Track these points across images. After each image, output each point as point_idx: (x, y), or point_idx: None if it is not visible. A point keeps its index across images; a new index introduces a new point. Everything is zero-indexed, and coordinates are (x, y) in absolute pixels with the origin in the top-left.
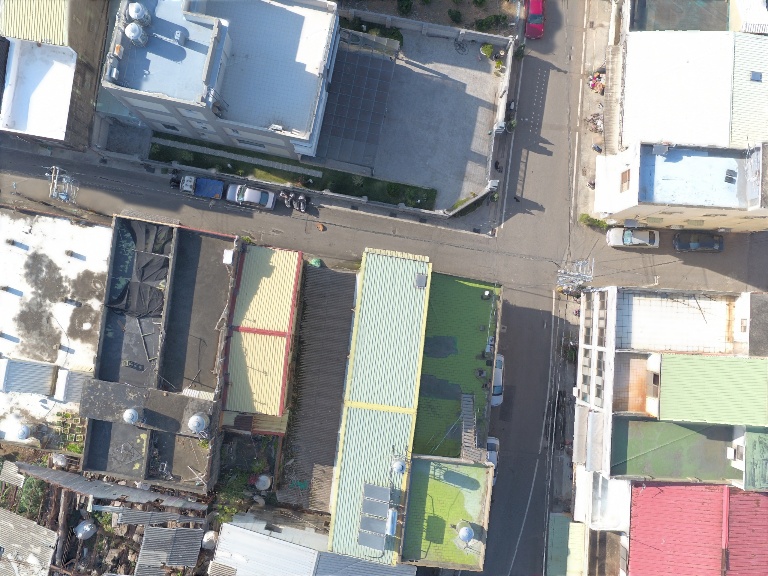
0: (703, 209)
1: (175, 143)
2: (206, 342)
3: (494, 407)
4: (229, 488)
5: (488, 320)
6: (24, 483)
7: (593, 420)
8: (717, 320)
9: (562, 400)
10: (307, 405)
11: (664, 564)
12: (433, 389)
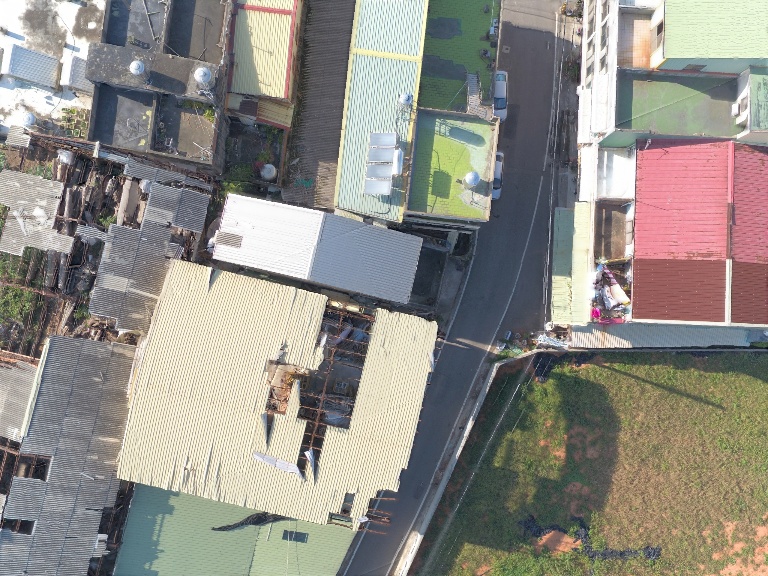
0: None
1: None
2: (211, 22)
3: None
4: (234, 178)
5: (492, 2)
6: None
7: (598, 81)
8: None
9: None
10: (312, 106)
11: (670, 223)
12: (438, 69)
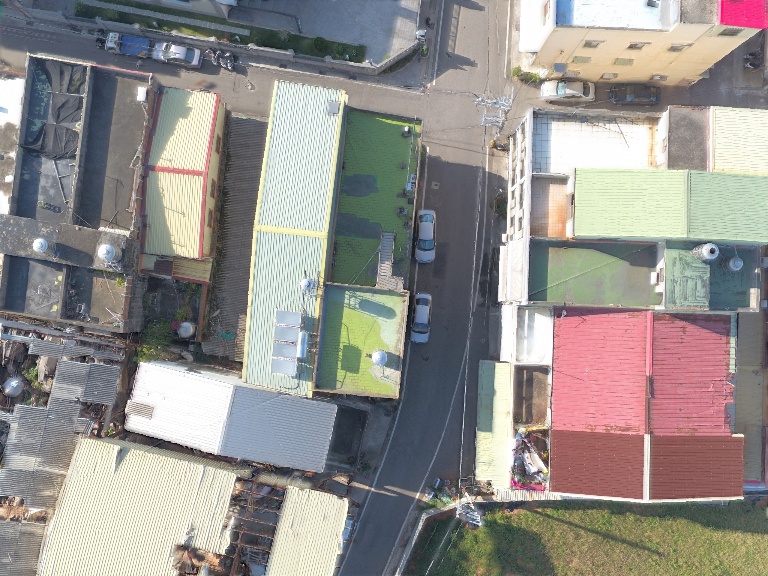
0: (624, 32)
1: (101, 3)
2: (123, 183)
3: (427, 264)
4: (151, 336)
5: None
6: None
7: (512, 248)
8: (640, 144)
9: (497, 257)
10: (232, 256)
11: (588, 394)
12: (354, 228)
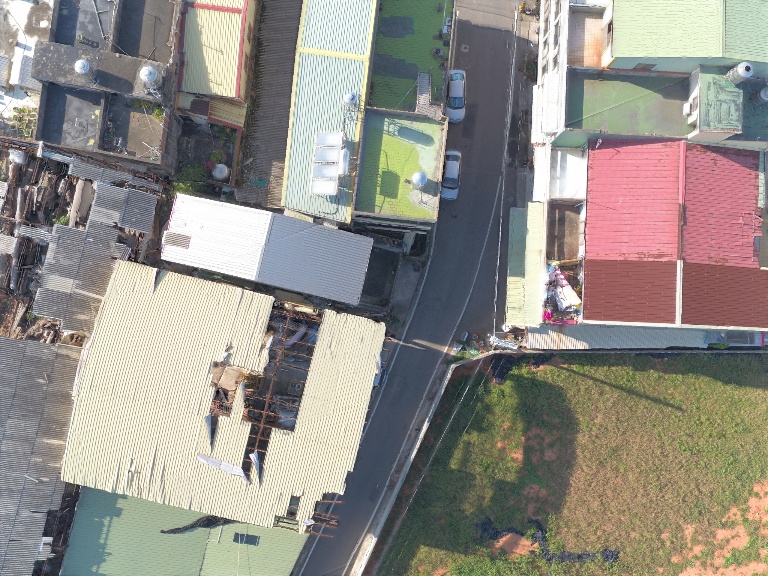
0: None
1: None
2: (161, 20)
3: (456, 125)
4: (186, 177)
5: (445, 1)
6: None
7: (549, 80)
8: None
9: (525, 119)
10: (266, 105)
11: (621, 224)
12: (390, 68)
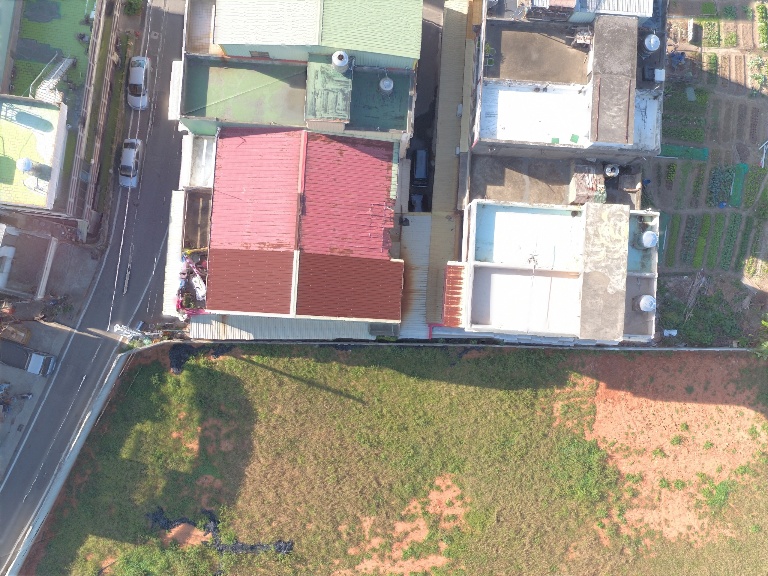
0: None
1: None
2: None
3: (142, 112)
4: None
5: None
6: None
7: (175, 67)
8: None
9: None
10: None
11: (244, 213)
12: (34, 53)
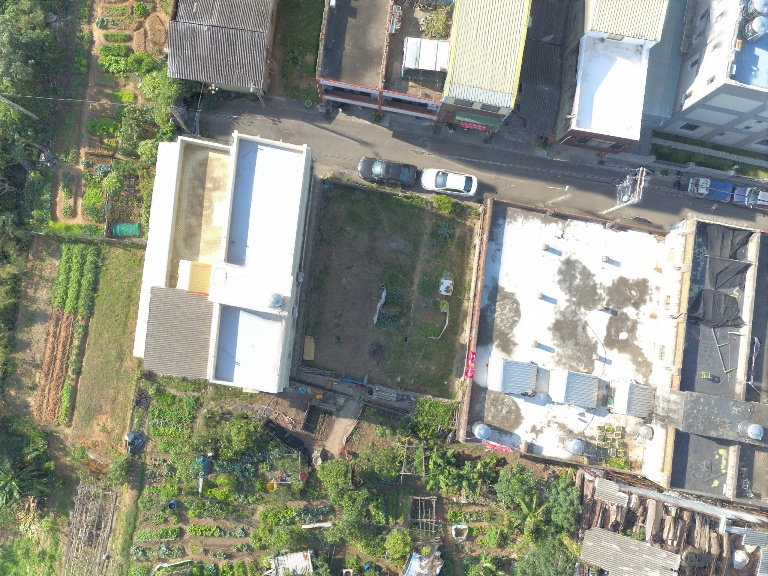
0: None
1: (675, 144)
2: None
3: None
4: None
5: None
6: (626, 502)
7: None
8: None
9: None
10: None
11: None
12: None
